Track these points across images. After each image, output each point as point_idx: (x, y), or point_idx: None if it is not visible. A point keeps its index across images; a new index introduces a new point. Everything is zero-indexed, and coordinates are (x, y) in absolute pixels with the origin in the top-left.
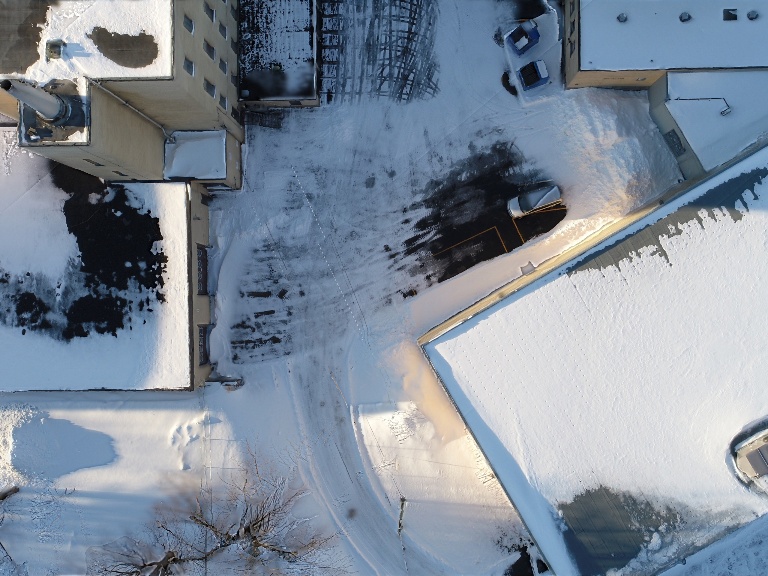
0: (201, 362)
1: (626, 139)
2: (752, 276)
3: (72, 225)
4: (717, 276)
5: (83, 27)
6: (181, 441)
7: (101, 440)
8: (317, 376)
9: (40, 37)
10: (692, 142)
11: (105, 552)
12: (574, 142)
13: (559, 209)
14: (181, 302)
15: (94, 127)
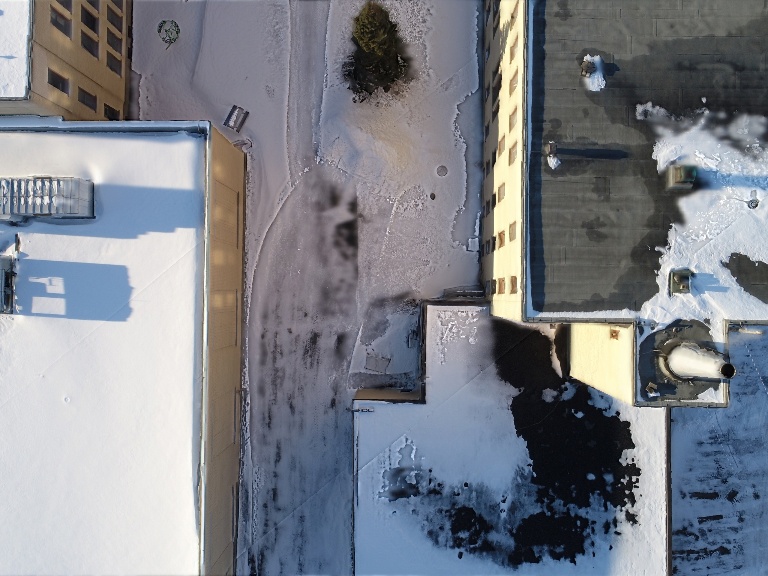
0: None
1: None
2: None
3: (521, 427)
4: None
5: (717, 253)
6: None
7: None
8: None
9: (659, 264)
10: None
11: None
12: None
13: None
14: (657, 525)
15: None
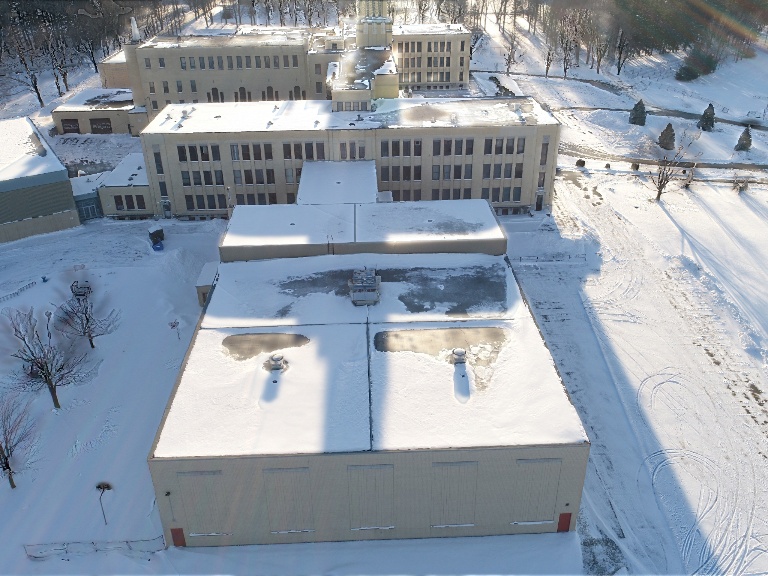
0: (65, 127)
1: None
2: None
3: None
4: None
5: None
6: None
7: None
8: None
9: None
10: None
11: (3, 98)
12: None
13: None
14: None
15: (130, 47)
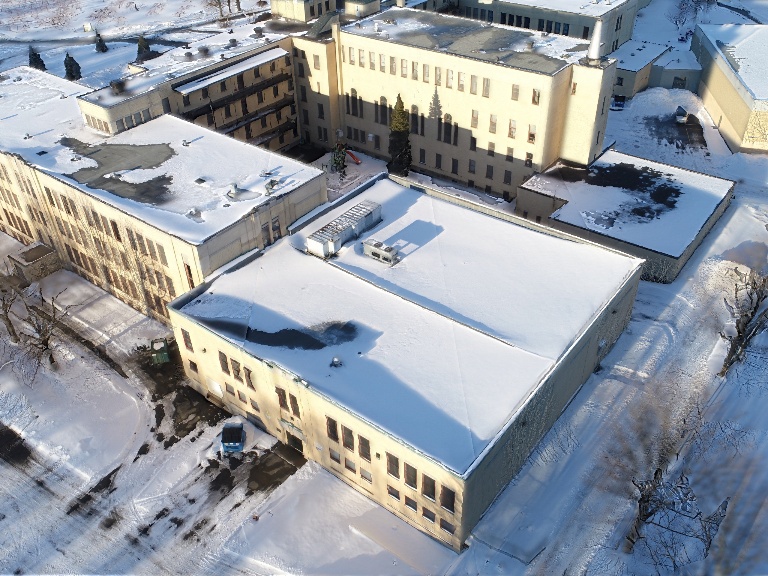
0: None
1: (669, 91)
2: (763, 50)
3: (602, 185)
4: (759, 54)
5: None
6: (765, 219)
7: (749, 245)
8: (742, 187)
9: None
10: (687, 69)
11: None
12: (660, 102)
13: (689, 115)
14: None
15: None
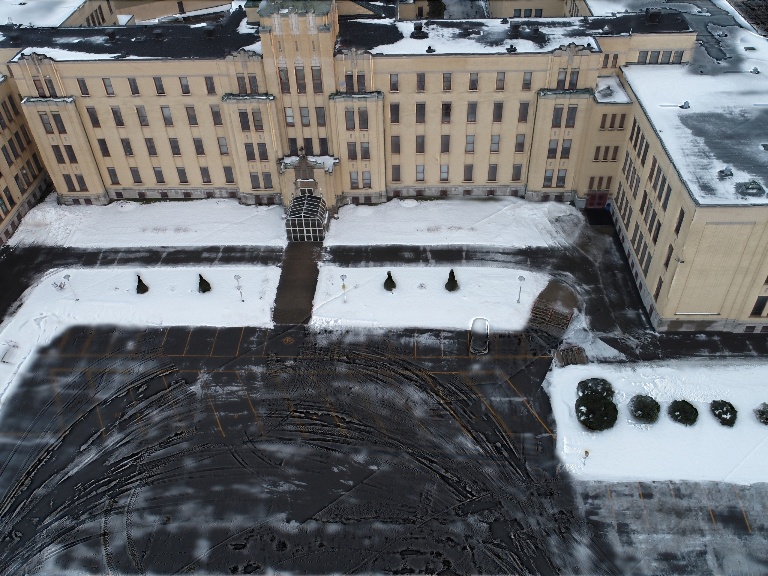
0: None
1: None
2: None
3: None
4: None
5: None
6: None
7: None
8: None
9: None
10: None
11: None
12: None
13: None
14: None
15: None
